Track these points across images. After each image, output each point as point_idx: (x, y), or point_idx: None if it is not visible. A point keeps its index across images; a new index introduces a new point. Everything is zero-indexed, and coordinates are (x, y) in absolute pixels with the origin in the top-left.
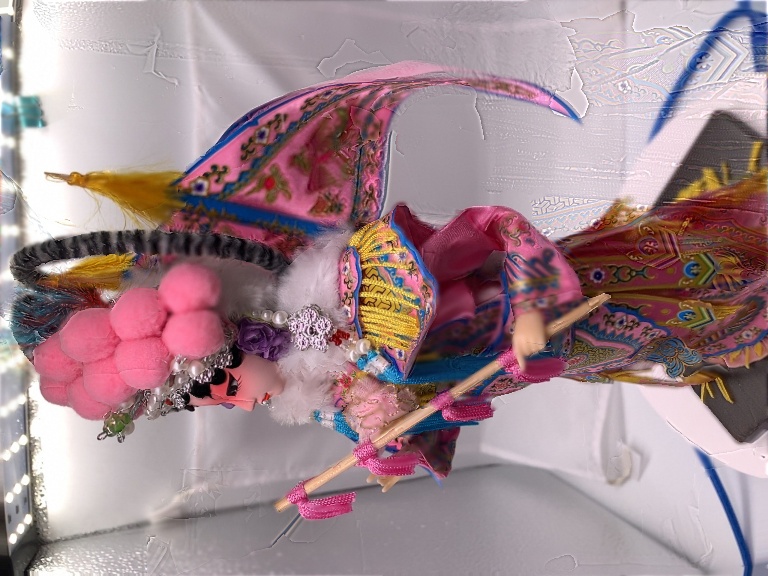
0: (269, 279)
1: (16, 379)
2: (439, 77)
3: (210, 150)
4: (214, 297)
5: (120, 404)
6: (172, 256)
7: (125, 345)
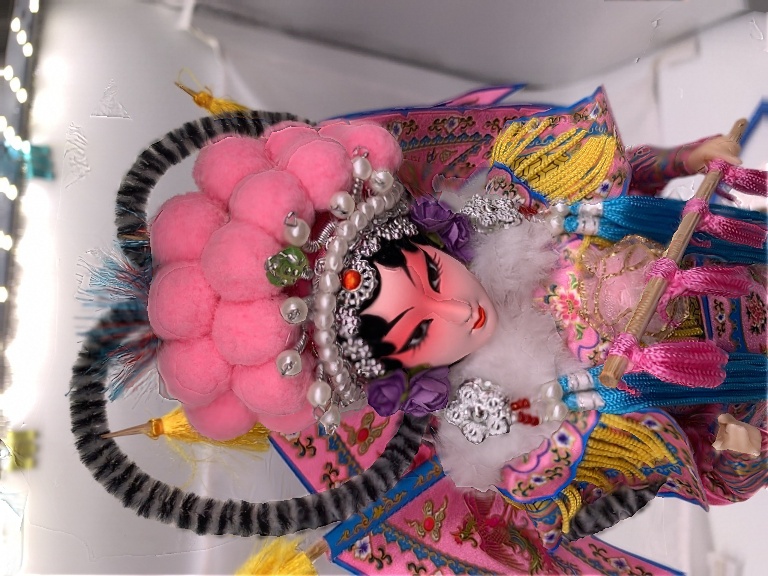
0: None
1: None
2: (476, 108)
3: (317, 120)
4: None
5: None
6: None
7: None
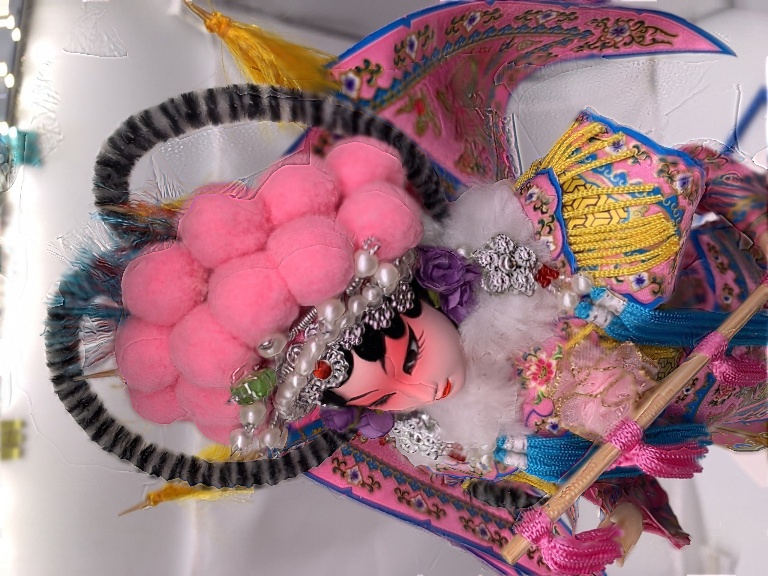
0: (432, 218)
1: (7, 492)
2: (587, 3)
3: (366, 35)
4: (402, 175)
5: (271, 334)
6: (337, 131)
7: (283, 232)
